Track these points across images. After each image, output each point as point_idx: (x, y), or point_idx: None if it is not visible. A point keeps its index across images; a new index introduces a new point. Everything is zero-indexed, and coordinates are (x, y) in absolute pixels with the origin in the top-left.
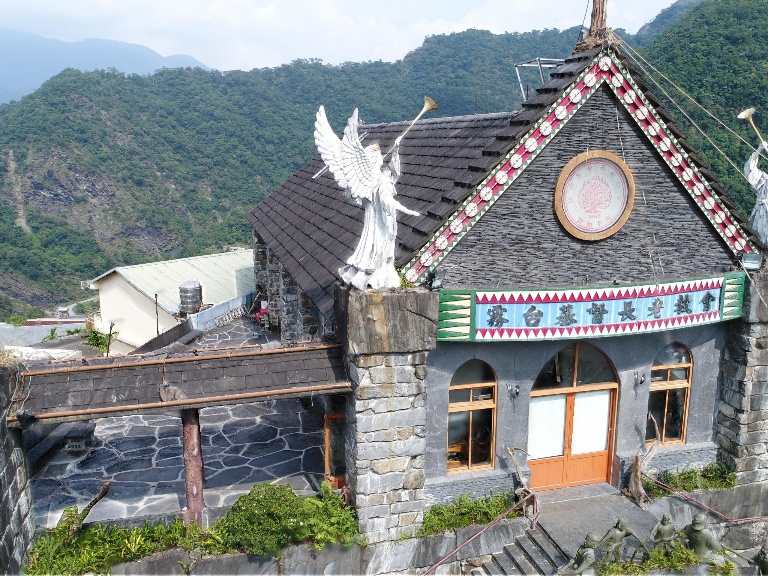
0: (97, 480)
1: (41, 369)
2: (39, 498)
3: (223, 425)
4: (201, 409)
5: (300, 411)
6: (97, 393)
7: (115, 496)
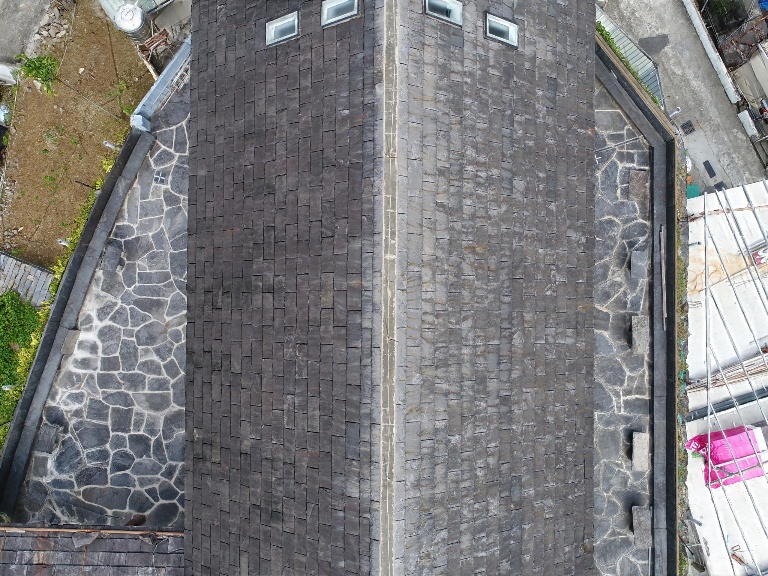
0: (71, 495)
1: None
2: (36, 510)
3: (163, 419)
4: (147, 377)
5: None
6: None
7: (85, 523)
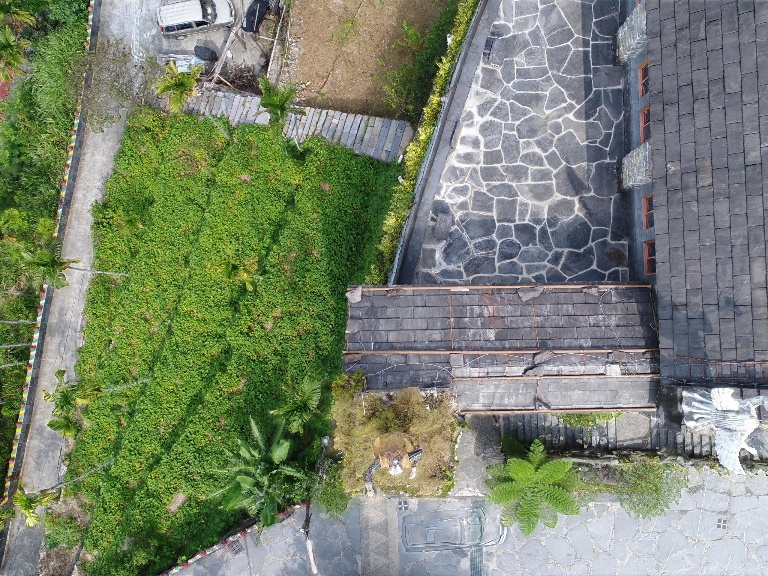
0: None
1: (461, 373)
2: None
3: (548, 208)
4: (529, 168)
5: (614, 194)
6: (496, 395)
7: None
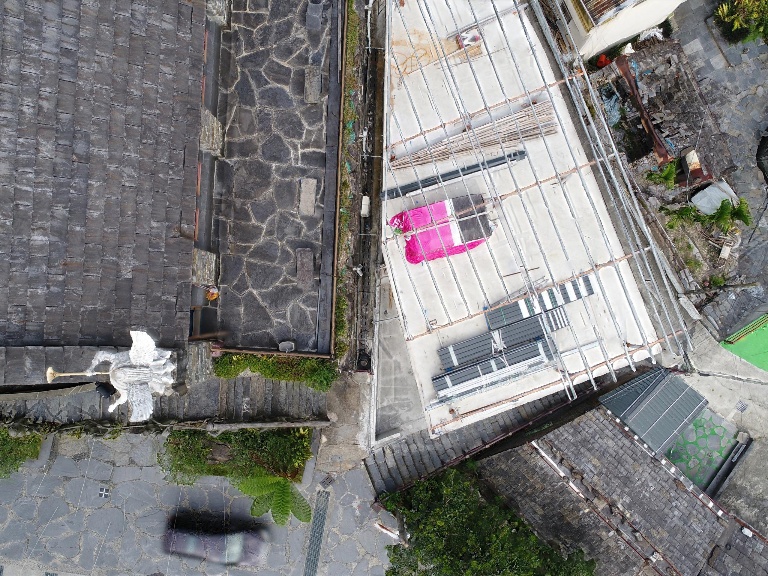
0: None
1: None
2: None
3: None
4: None
5: None
6: None
7: None
